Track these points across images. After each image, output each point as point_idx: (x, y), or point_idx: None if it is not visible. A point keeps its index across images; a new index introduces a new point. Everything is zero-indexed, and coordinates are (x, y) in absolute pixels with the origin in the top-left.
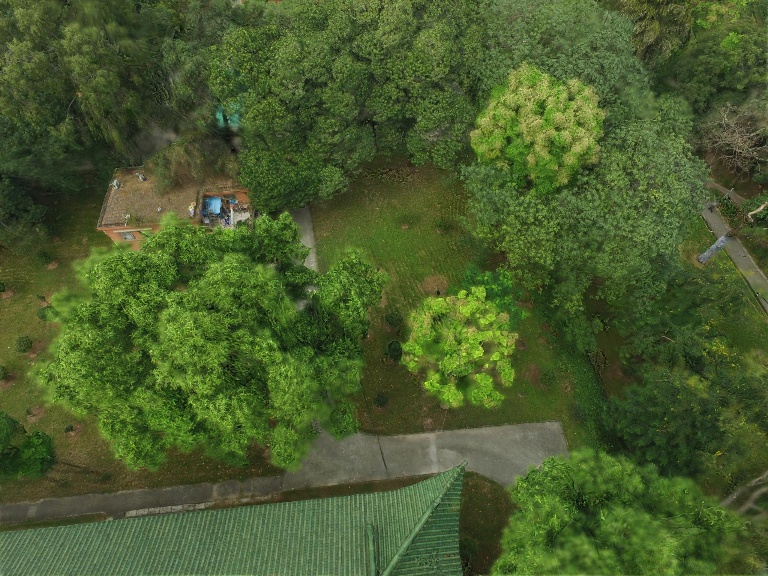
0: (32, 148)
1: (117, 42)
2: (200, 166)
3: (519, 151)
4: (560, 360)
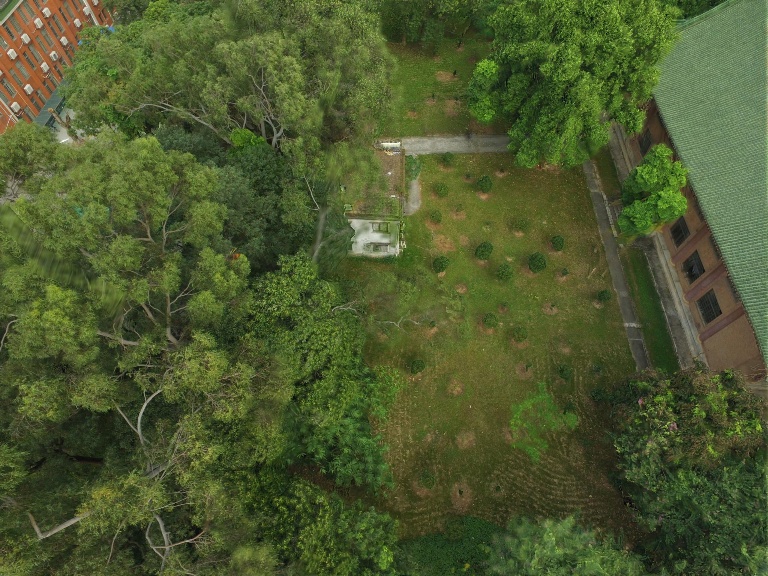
0: (339, 212)
1: None
2: None
3: None
4: None
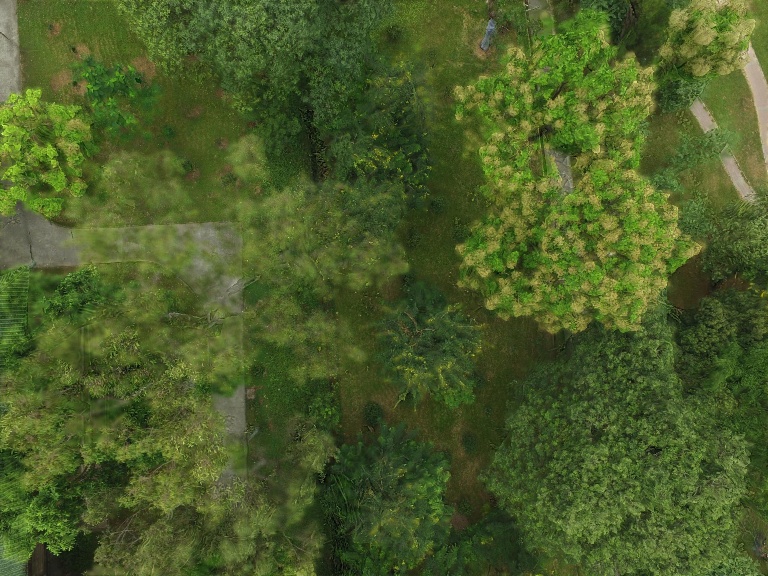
0: None
1: None
2: None
3: None
4: (259, 162)
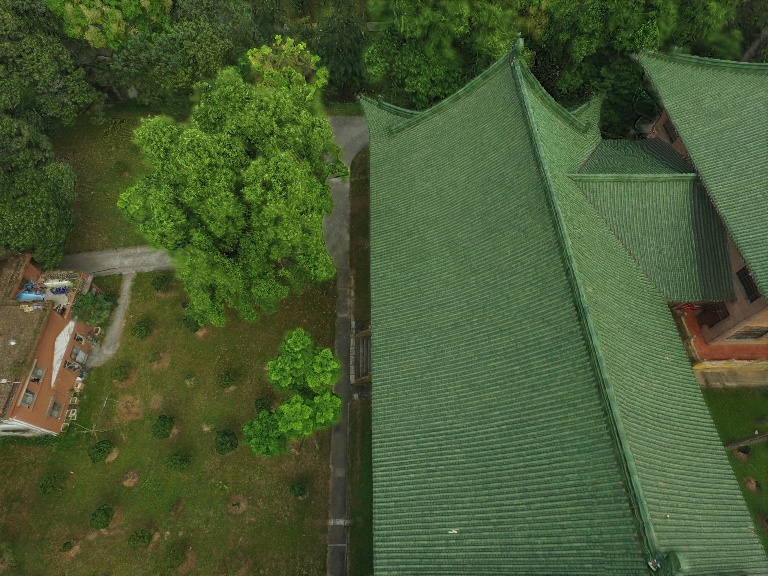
0: None
1: None
2: None
3: (133, 6)
4: None
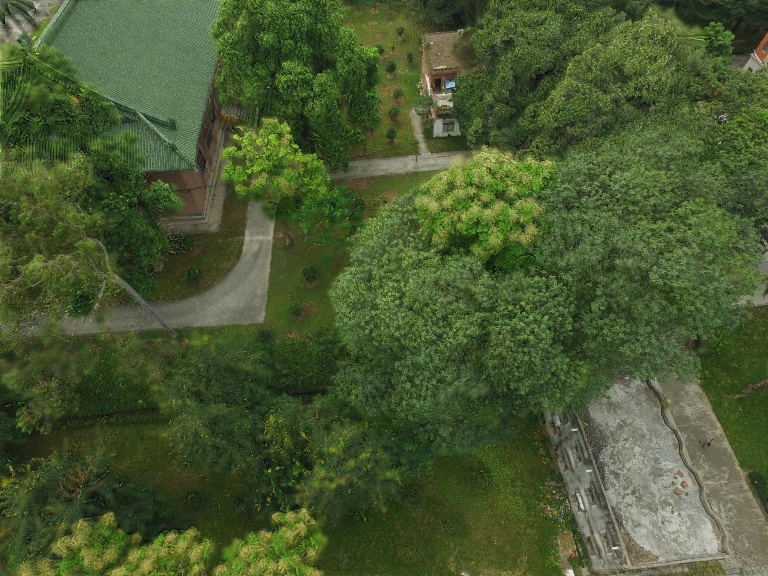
0: None
1: (658, 11)
2: (462, 48)
3: None
4: None
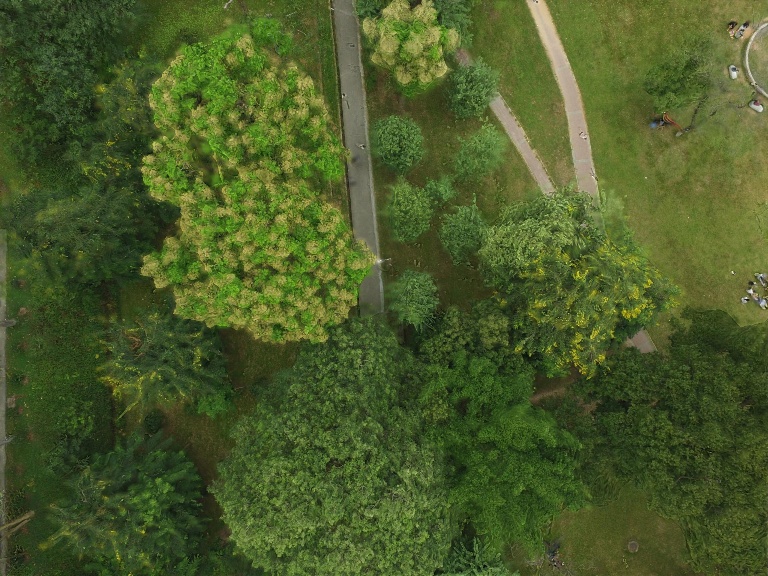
0: None
1: None
2: None
3: None
4: (26, 168)
